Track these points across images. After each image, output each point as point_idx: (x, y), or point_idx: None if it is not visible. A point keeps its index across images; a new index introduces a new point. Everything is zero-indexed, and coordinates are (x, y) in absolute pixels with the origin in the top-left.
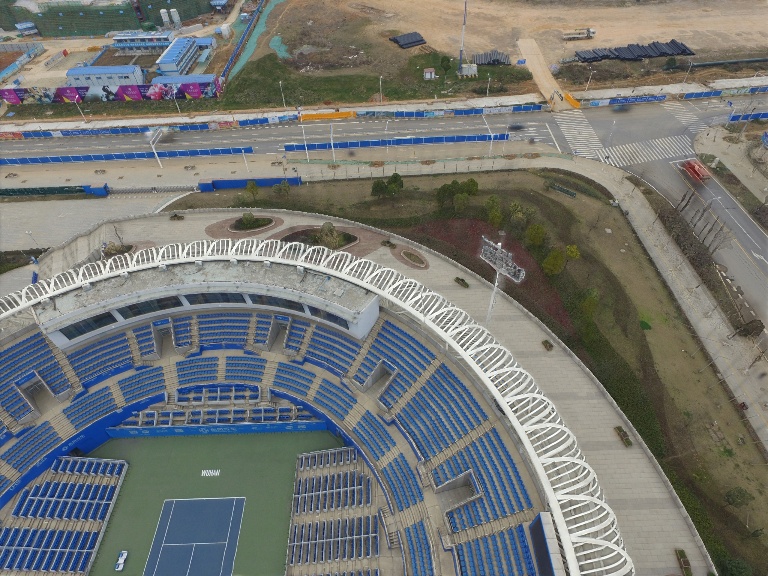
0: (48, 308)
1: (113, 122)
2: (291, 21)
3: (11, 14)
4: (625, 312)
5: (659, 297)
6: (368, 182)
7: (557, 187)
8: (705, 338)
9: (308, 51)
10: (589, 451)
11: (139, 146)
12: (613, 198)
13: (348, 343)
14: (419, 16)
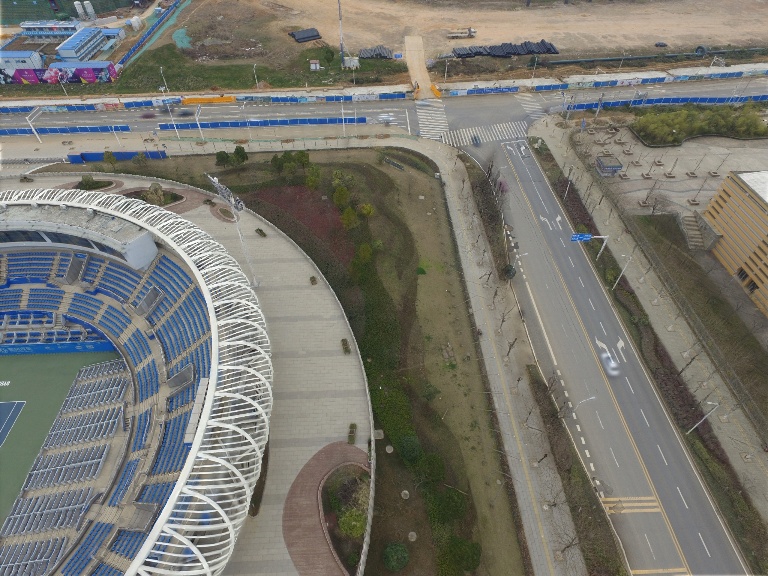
0: None
1: (7, 103)
2: (202, 16)
3: None
4: (407, 260)
5: (444, 250)
6: None
7: (390, 161)
8: (470, 282)
9: (210, 43)
10: (313, 357)
11: (25, 124)
12: (438, 171)
13: (132, 275)
14: (323, 14)
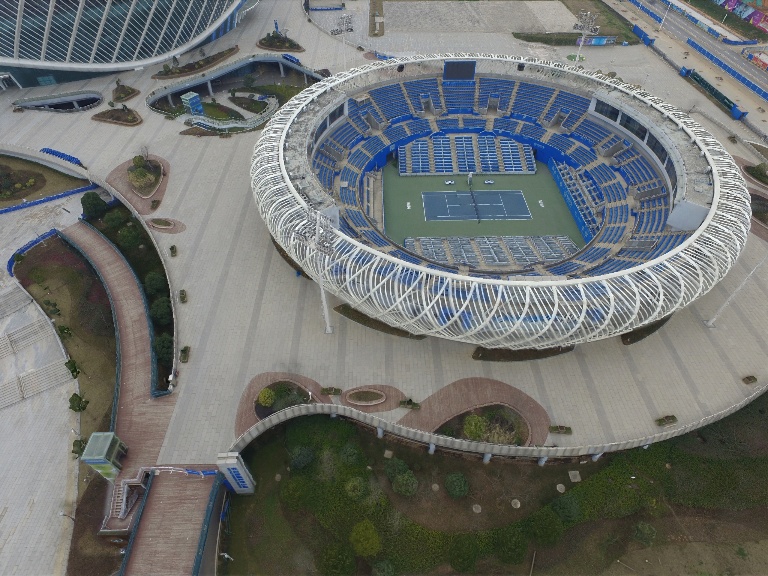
0: (608, 90)
1: None
2: None
3: None
4: None
5: None
6: None
7: None
8: None
9: None
10: (638, 389)
11: None
12: None
13: (662, 226)
14: None
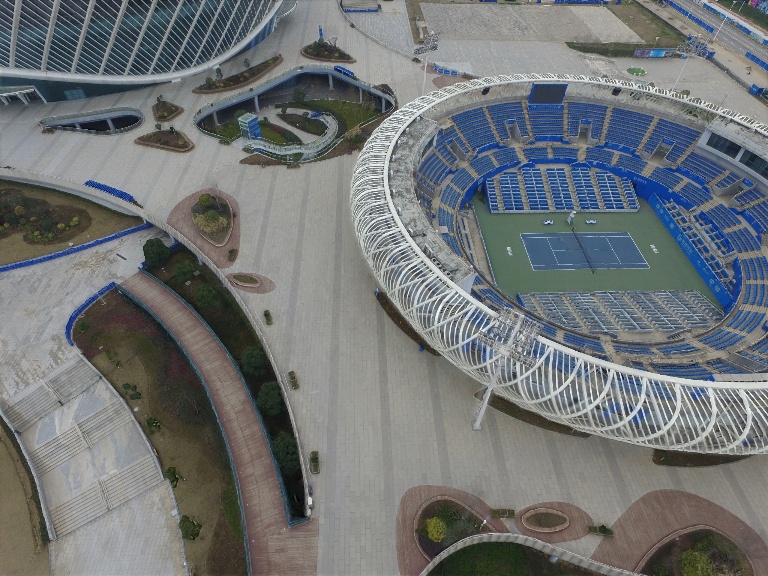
0: (724, 122)
1: None
2: None
3: None
4: None
5: None
6: None
7: None
8: None
9: None
10: None
11: None
12: None
13: None
14: None
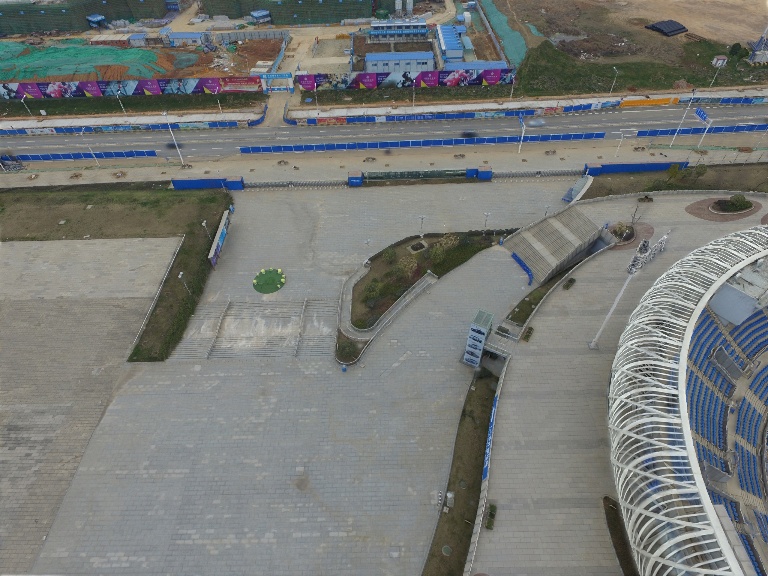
0: (743, 283)
1: (421, 108)
2: (525, 9)
3: (238, 2)
4: None
5: None
6: (758, 167)
7: None
8: None
9: (567, 39)
10: None
11: (474, 131)
12: None
13: None
14: (655, 4)
